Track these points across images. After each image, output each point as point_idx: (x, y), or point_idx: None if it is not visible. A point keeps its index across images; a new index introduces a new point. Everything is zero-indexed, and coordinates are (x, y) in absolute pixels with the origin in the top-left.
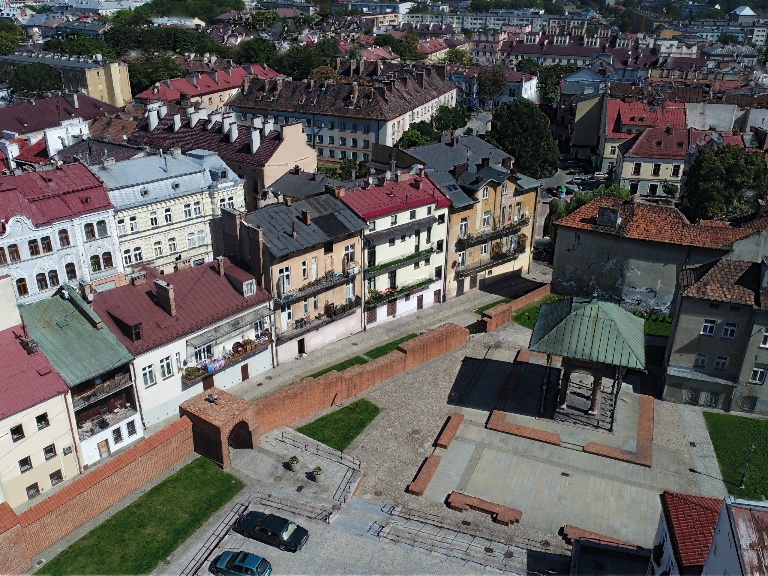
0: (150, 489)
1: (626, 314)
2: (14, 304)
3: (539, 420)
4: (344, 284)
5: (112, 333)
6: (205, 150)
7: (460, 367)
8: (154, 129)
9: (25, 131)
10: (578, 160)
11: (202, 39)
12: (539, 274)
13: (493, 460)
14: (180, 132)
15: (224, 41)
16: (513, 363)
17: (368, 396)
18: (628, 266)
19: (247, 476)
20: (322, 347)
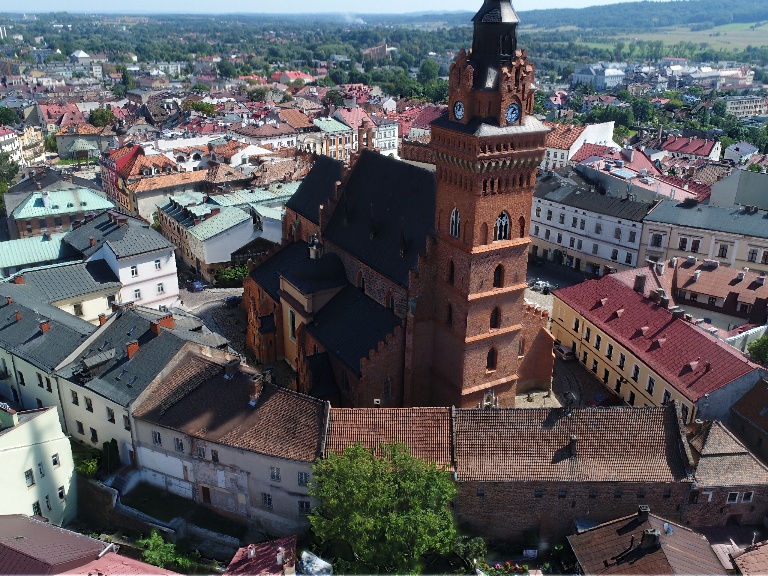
0: None
1: None
2: None
3: None
4: None
5: None
6: None
7: None
8: None
9: None
10: None
11: None
12: None
13: None
14: None
15: None
16: None
17: None
18: None
19: None
20: None
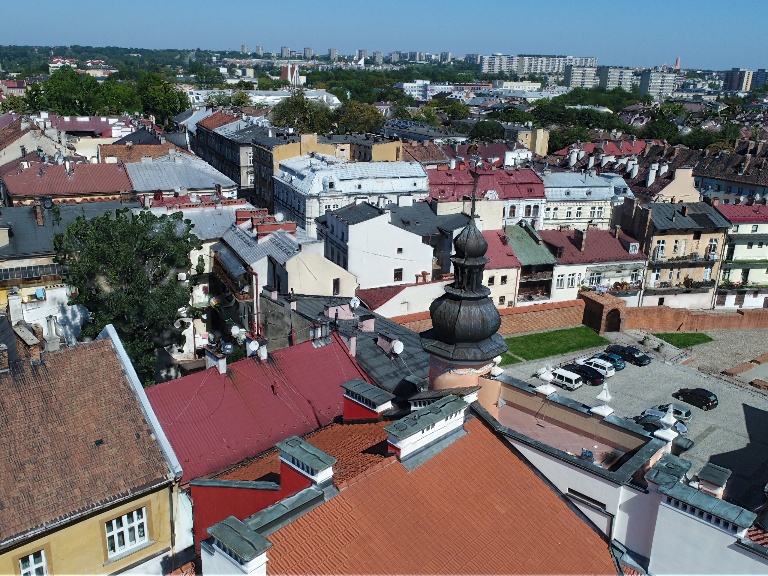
0: (555, 330)
1: None
2: (501, 217)
3: None
4: (704, 267)
5: None
6: None
7: None
8: (572, 166)
9: None
10: None
11: (612, 119)
12: None
13: None
14: None
15: (630, 123)
16: None
17: (706, 333)
18: None
19: (614, 340)
20: None
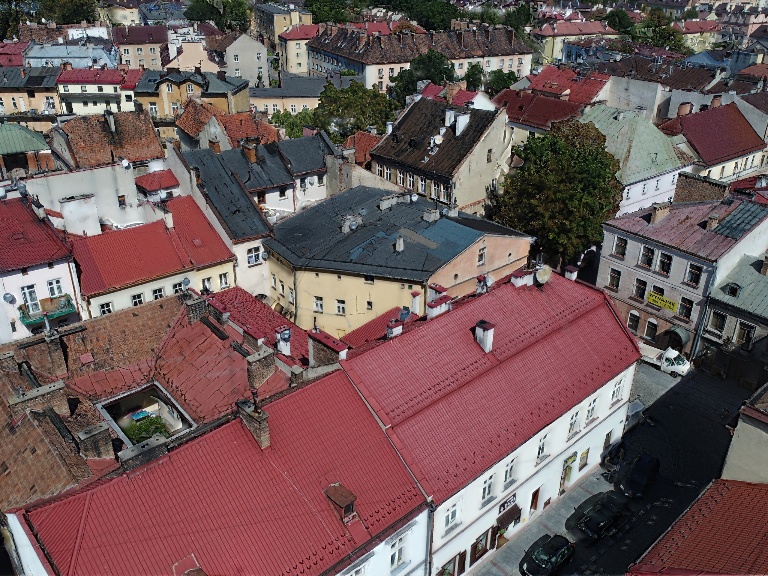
0: None
1: (29, 138)
2: None
3: None
4: (49, 121)
5: None
6: (99, 46)
7: None
8: None
9: (148, 42)
10: None
11: (427, 2)
12: None
13: None
14: None
15: None
16: None
17: None
18: None
19: None
20: None
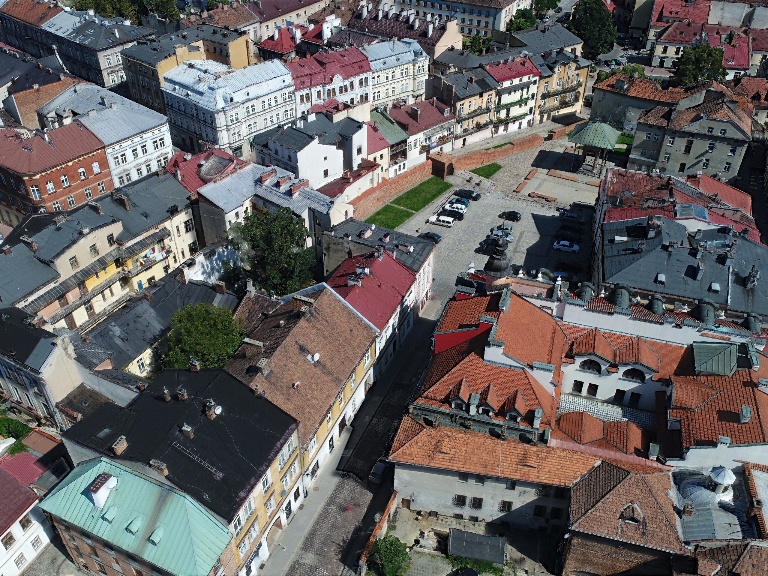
0: (420, 184)
1: (612, 129)
2: None
3: (570, 173)
4: (486, 113)
5: (399, 127)
6: (411, 39)
7: (538, 153)
8: (365, 18)
9: (280, 14)
10: (633, 39)
11: None
12: (586, 114)
13: (548, 185)
14: (382, 21)
15: None
16: (563, 153)
17: (497, 162)
18: (628, 110)
19: (453, 183)
20: (473, 143)
